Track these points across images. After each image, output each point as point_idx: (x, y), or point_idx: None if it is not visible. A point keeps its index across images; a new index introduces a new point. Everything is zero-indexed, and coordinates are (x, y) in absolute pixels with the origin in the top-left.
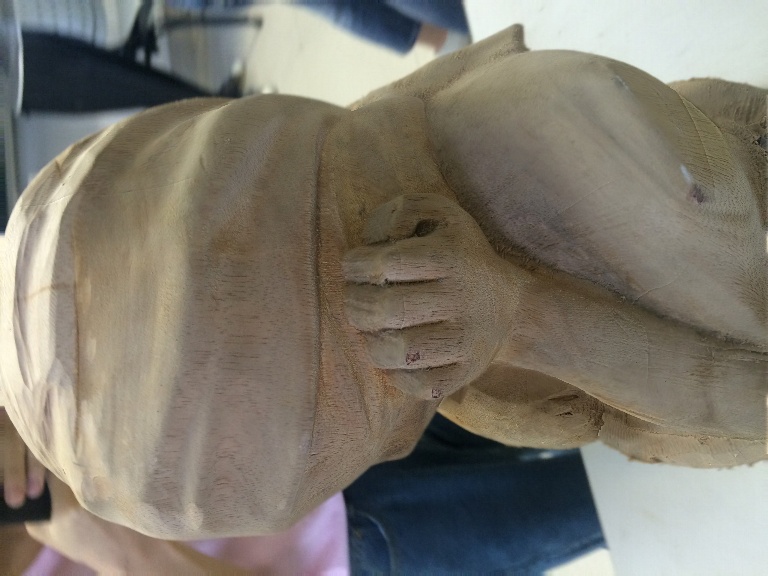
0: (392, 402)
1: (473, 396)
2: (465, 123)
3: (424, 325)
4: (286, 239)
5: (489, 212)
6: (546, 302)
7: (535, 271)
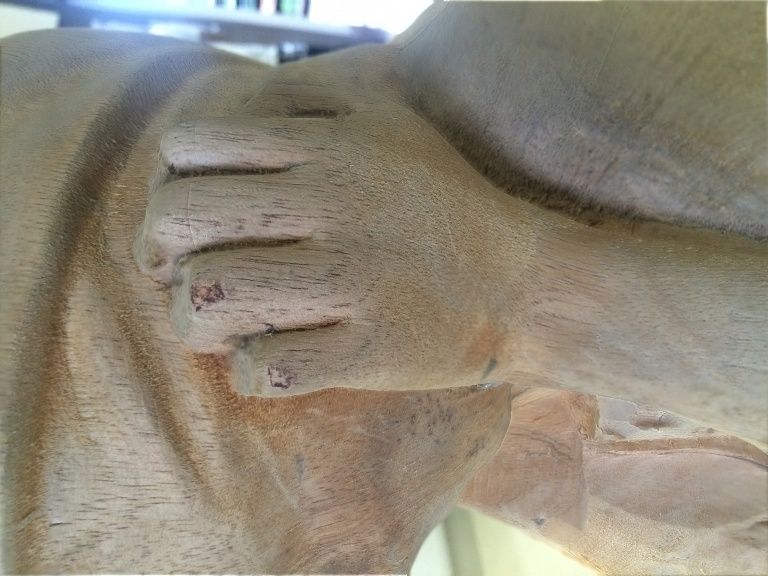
0: (264, 435)
1: (601, 514)
2: (437, 28)
3: (252, 244)
4: (39, 145)
5: (492, 143)
6: (605, 256)
7: (596, 226)
